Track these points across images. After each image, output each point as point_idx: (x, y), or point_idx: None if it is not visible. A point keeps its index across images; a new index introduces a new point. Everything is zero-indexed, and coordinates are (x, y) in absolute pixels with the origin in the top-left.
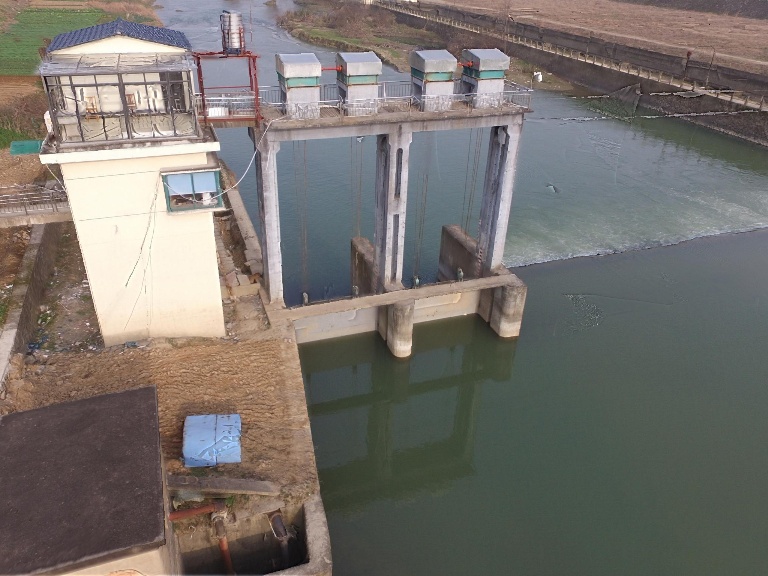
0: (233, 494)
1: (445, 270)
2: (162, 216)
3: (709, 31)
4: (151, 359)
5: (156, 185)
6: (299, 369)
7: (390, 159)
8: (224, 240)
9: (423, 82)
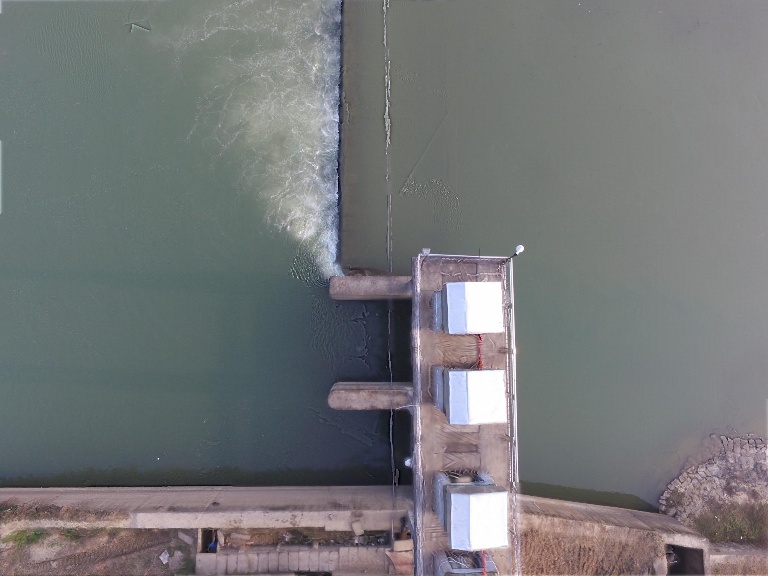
0: None
1: None
2: None
3: None
4: None
5: None
6: (543, 518)
7: None
8: (268, 542)
9: None
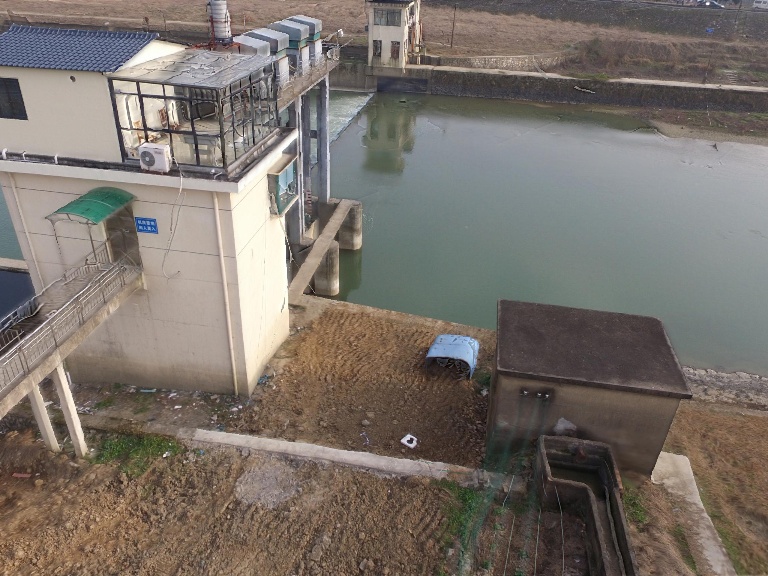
0: None
1: None
2: (268, 224)
3: (77, 0)
4: (304, 371)
5: (267, 190)
6: None
7: (296, 124)
8: None
9: (299, 49)
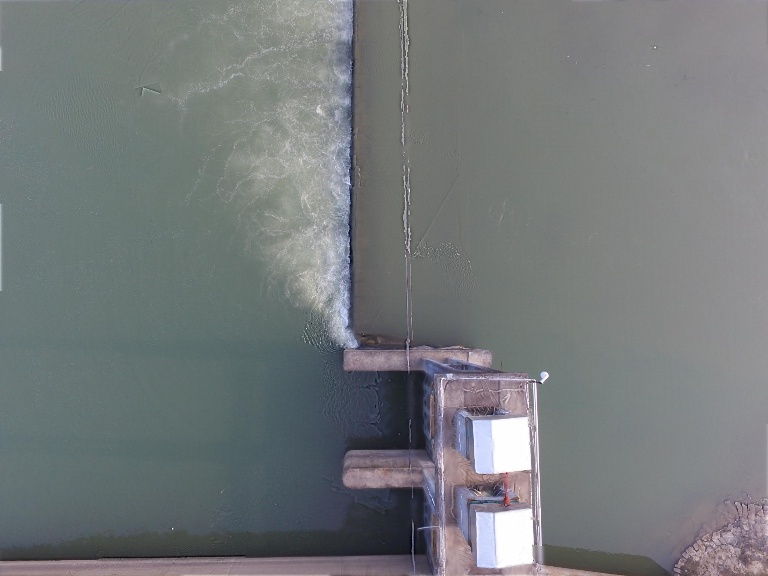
0: None
1: None
2: None
3: None
4: None
5: None
6: None
7: None
8: None
9: None
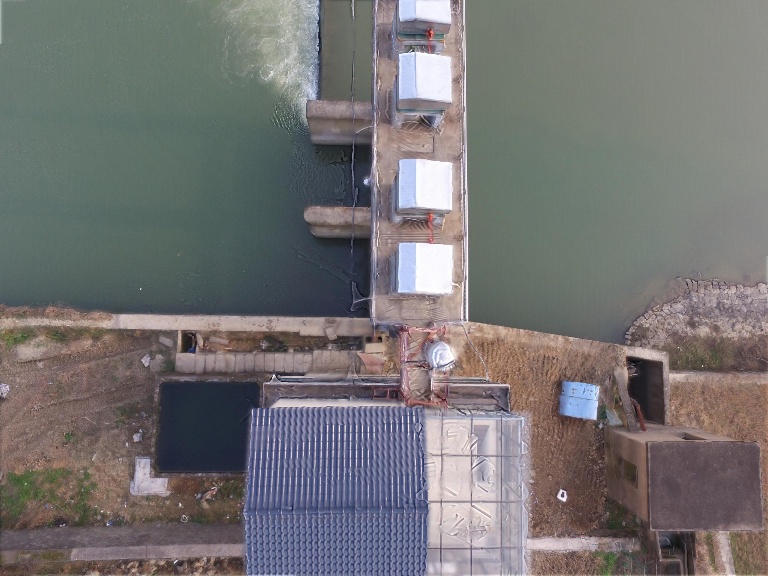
0: (616, 393)
1: (327, 138)
2: None
3: None
4: None
5: None
6: (509, 329)
7: None
8: (246, 349)
9: None
